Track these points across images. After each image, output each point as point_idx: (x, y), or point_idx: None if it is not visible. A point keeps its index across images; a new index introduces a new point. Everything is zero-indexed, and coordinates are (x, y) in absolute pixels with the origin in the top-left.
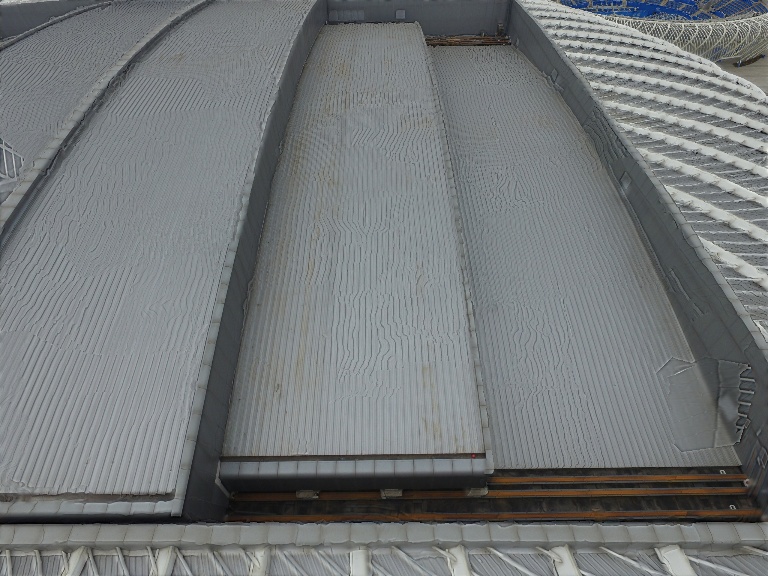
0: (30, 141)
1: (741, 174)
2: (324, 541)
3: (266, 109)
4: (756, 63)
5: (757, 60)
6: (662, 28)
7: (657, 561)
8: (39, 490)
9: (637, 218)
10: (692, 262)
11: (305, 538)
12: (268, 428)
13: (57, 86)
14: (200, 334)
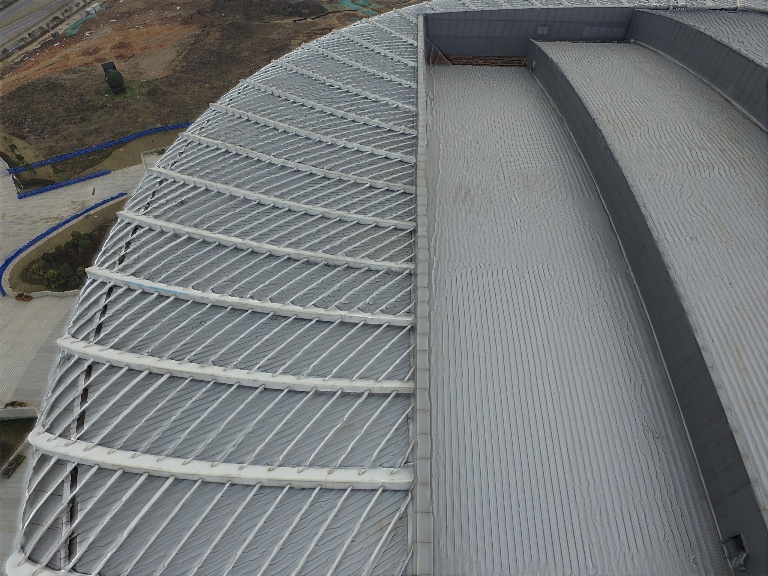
0: None
1: None
2: None
3: None
4: None
5: None
6: None
7: None
8: None
9: None
10: None
11: None
12: None
13: None
14: None
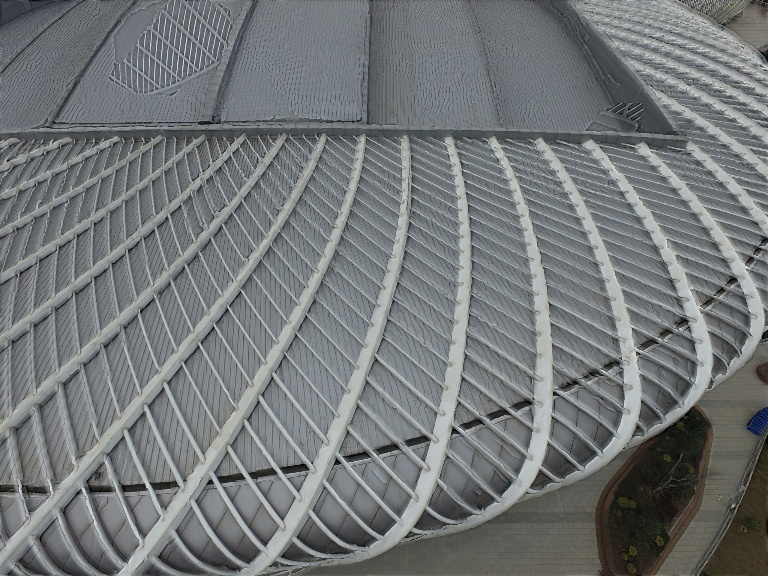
0: (229, 2)
1: None
2: (434, 129)
3: None
4: None
5: None
6: None
7: None
8: (300, 116)
9: (591, 54)
10: (618, 65)
11: None
12: None
13: None
14: (359, 70)
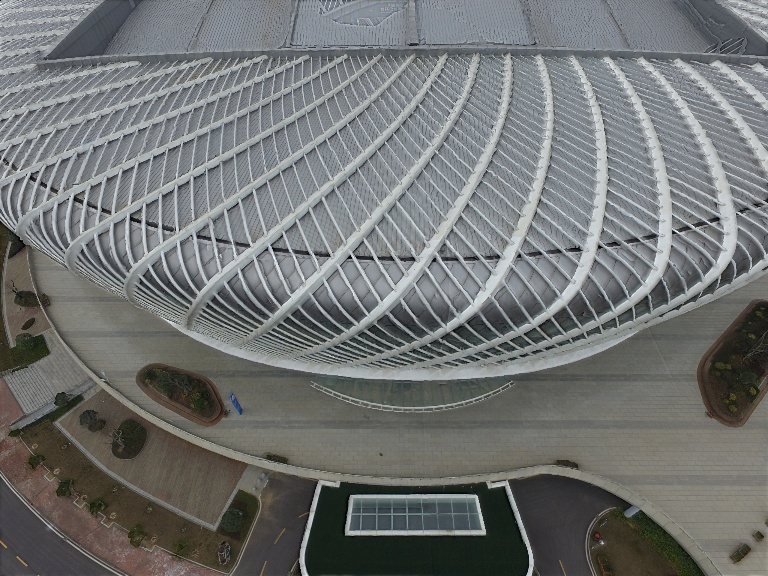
0: None
1: None
2: None
3: None
4: None
5: None
6: None
7: None
8: (487, 40)
9: (691, 4)
10: (720, 10)
11: None
12: None
13: None
14: (523, 7)
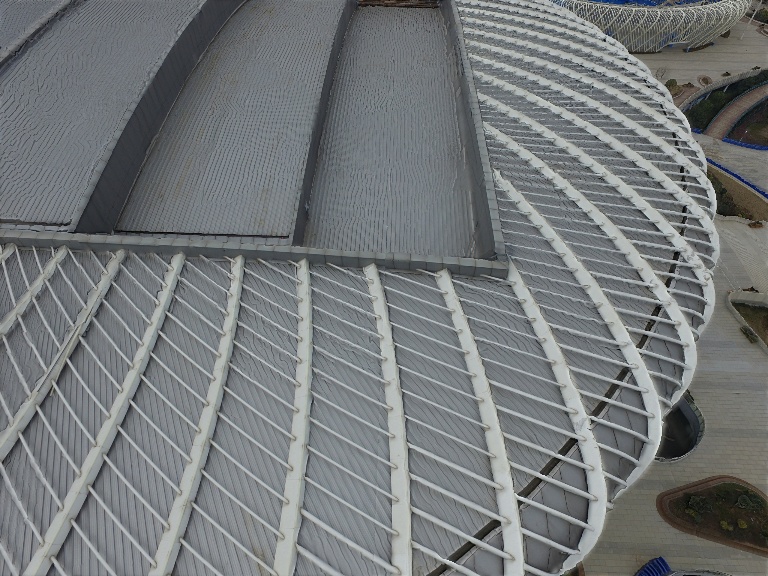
0: (7, 36)
1: (553, 94)
2: (155, 244)
3: (184, 22)
4: (704, 50)
5: (706, 47)
6: (614, 12)
7: (361, 273)
8: None
9: (456, 116)
10: (473, 137)
11: (144, 243)
12: (150, 217)
13: (33, 4)
14: (103, 145)
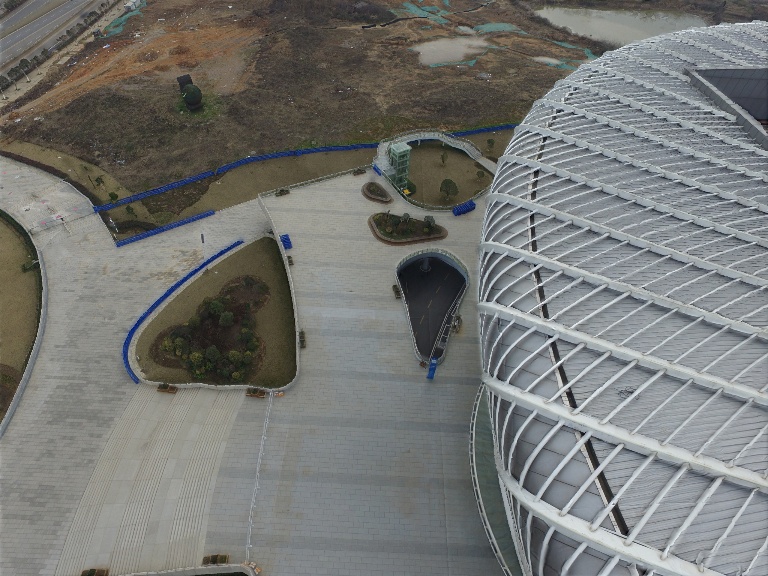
0: None
1: None
2: None
3: None
4: None
5: None
6: None
7: None
8: None
9: None
10: None
11: None
12: None
13: None
14: None
